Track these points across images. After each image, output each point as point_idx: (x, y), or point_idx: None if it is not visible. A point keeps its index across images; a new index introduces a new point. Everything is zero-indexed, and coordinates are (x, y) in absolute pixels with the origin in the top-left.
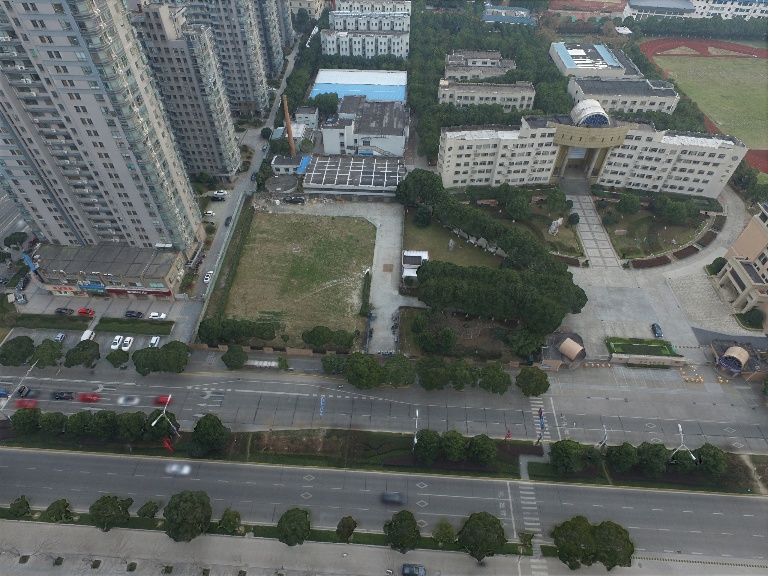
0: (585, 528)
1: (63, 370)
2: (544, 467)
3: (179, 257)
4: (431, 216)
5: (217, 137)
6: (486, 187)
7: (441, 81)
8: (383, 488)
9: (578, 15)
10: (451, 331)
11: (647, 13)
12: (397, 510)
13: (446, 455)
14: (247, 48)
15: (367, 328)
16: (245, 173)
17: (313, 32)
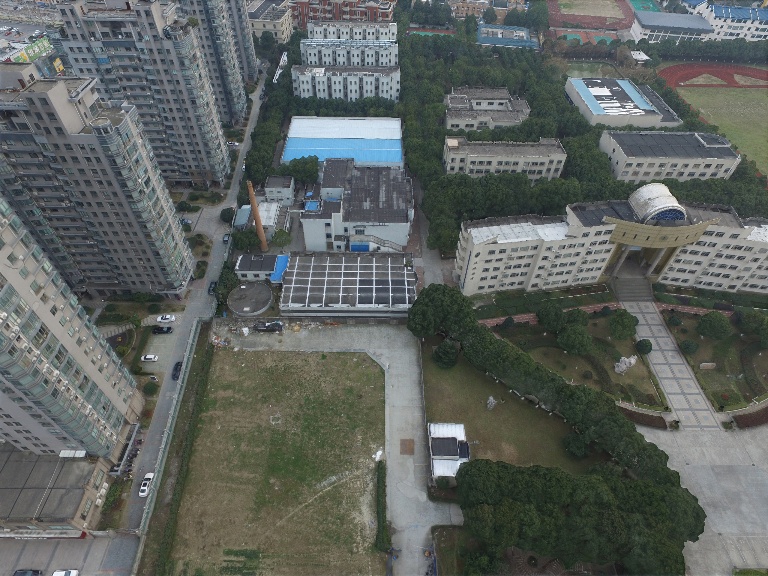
0: None
1: None
2: None
3: (98, 468)
4: (458, 353)
5: (156, 250)
6: (520, 292)
7: (448, 141)
8: None
9: (581, 34)
10: None
11: (660, 33)
12: None
13: None
14: (197, 108)
15: None
16: (200, 281)
17: (281, 62)
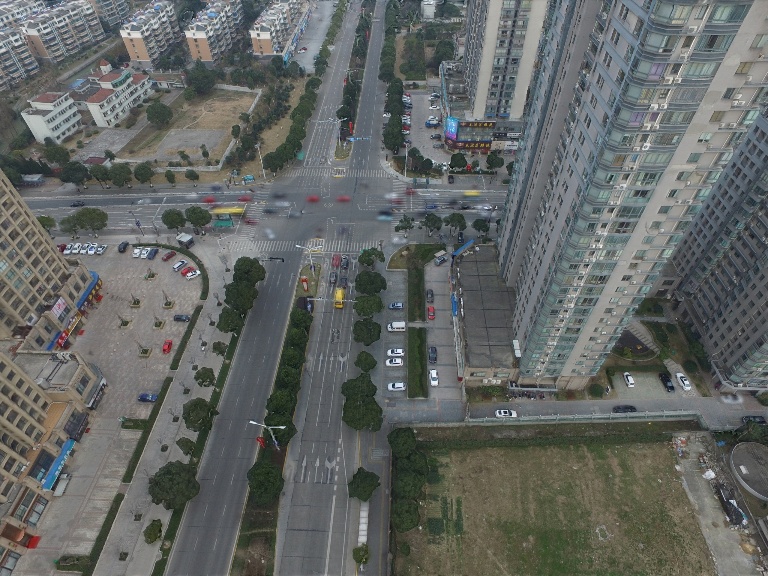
0: None
1: None
2: None
3: (510, 371)
4: None
5: (765, 340)
6: None
7: None
8: None
9: None
10: None
11: None
12: None
13: None
14: None
15: None
16: (756, 403)
17: None
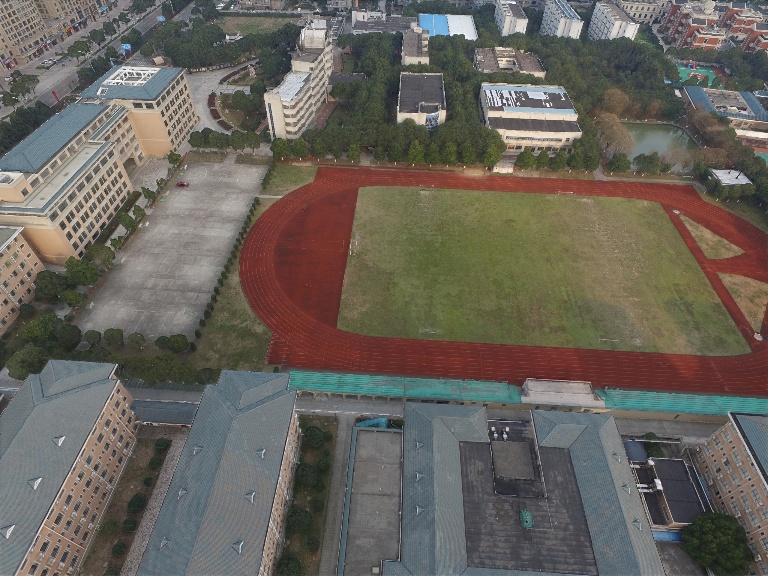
0: (81, 42)
1: None
2: None
3: None
4: None
5: None
6: None
7: (418, 27)
8: None
9: None
10: (174, 29)
11: None
12: None
13: None
14: None
15: None
16: None
17: None
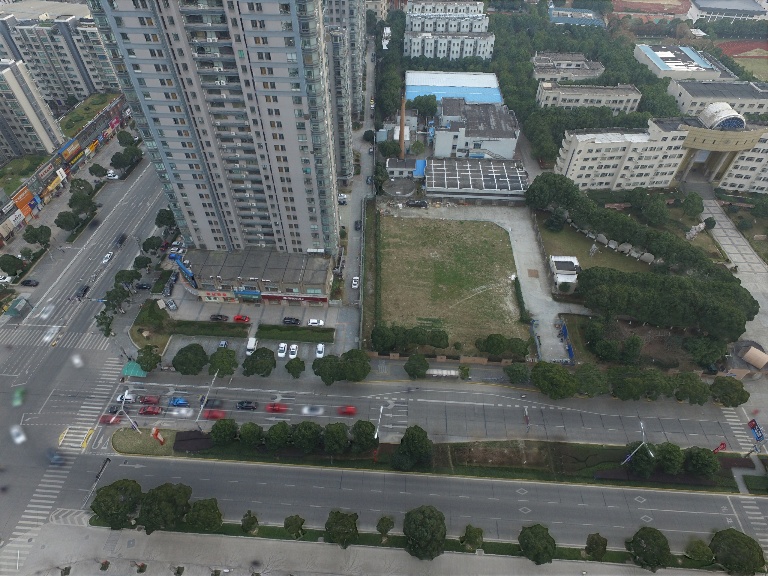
0: None
1: (235, 379)
2: (762, 481)
3: (330, 262)
4: (565, 220)
5: (343, 140)
6: (606, 191)
7: (544, 83)
8: (601, 502)
9: (642, 17)
10: (640, 339)
11: (716, 15)
12: (623, 525)
13: (663, 468)
14: (354, 50)
15: (532, 335)
16: (358, 176)
17: (386, 34)
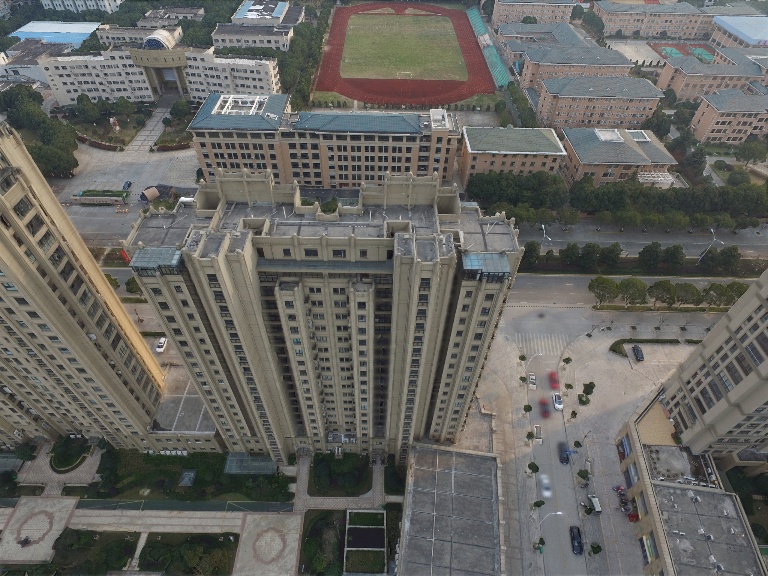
0: None
1: None
2: None
3: None
4: None
5: None
6: None
7: (100, 25)
8: None
9: None
10: None
11: None
12: None
13: None
14: None
15: None
16: None
17: None
